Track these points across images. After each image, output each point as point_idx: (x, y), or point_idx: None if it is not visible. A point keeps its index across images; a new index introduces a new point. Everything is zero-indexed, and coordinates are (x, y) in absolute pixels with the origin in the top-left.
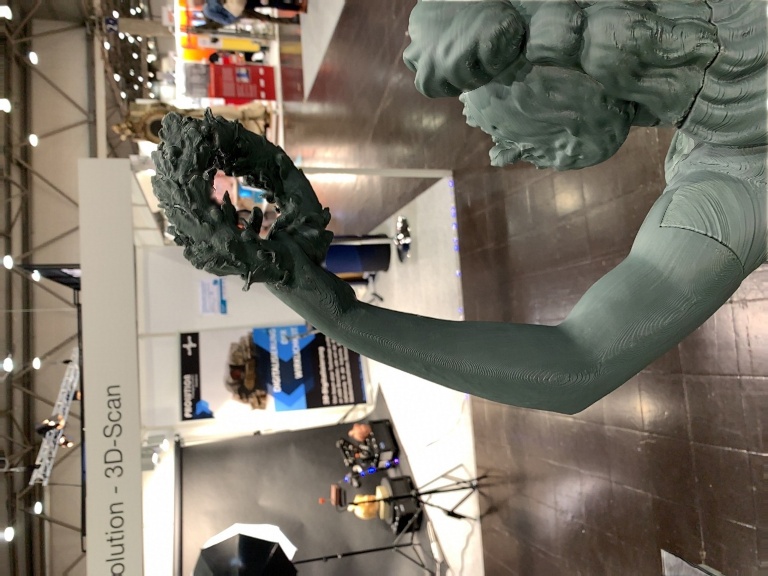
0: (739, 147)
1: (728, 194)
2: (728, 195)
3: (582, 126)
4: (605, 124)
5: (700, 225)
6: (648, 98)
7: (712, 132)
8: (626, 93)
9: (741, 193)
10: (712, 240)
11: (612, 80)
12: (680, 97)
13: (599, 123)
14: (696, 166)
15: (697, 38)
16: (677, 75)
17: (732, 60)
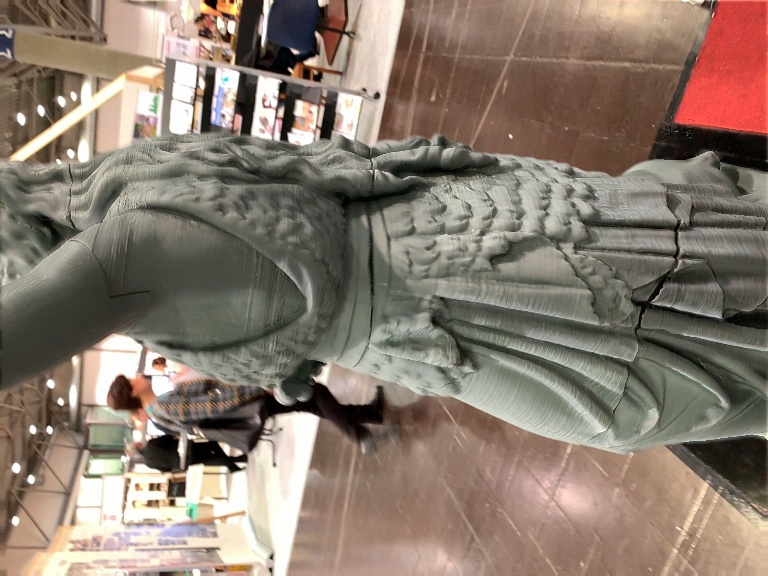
0: None
1: None
2: None
3: (2, 241)
4: (21, 237)
5: None
6: (38, 205)
7: (86, 211)
8: (23, 206)
9: None
10: None
11: (4, 194)
12: (59, 198)
13: (14, 236)
14: None
15: (58, 163)
16: (53, 187)
17: (79, 165)
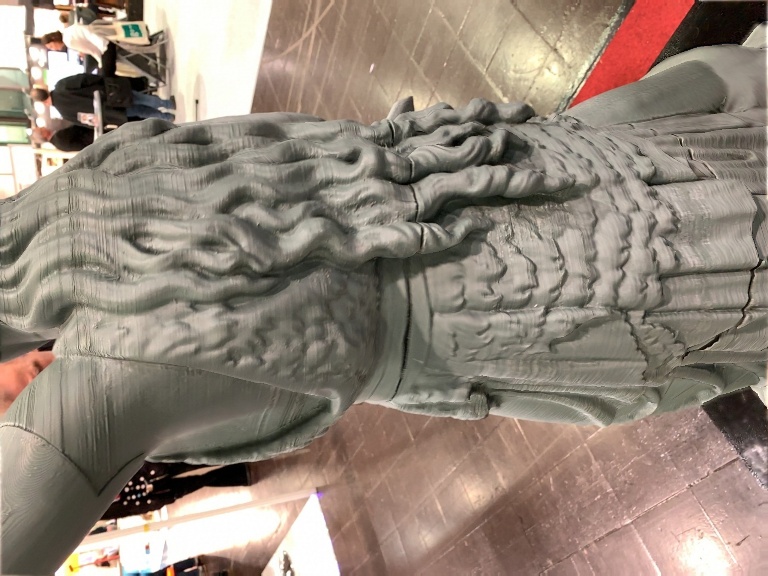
0: (59, 327)
1: (44, 376)
2: (44, 377)
3: None
4: None
5: (12, 417)
6: None
7: (22, 317)
8: None
9: (54, 371)
10: (18, 429)
11: None
12: None
13: None
14: None
15: None
16: None
17: None
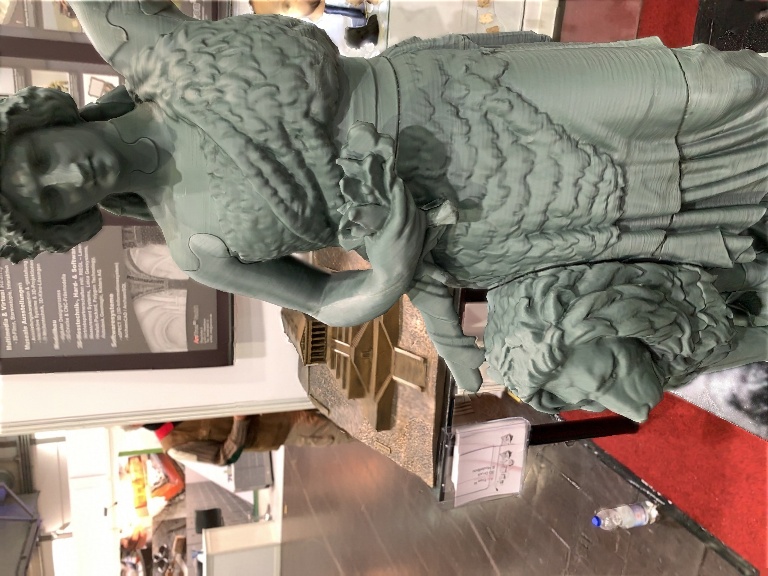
0: None
1: None
2: None
3: None
4: None
5: None
6: None
7: None
8: None
9: None
10: None
11: None
12: None
13: None
14: None
15: None
16: None
17: None
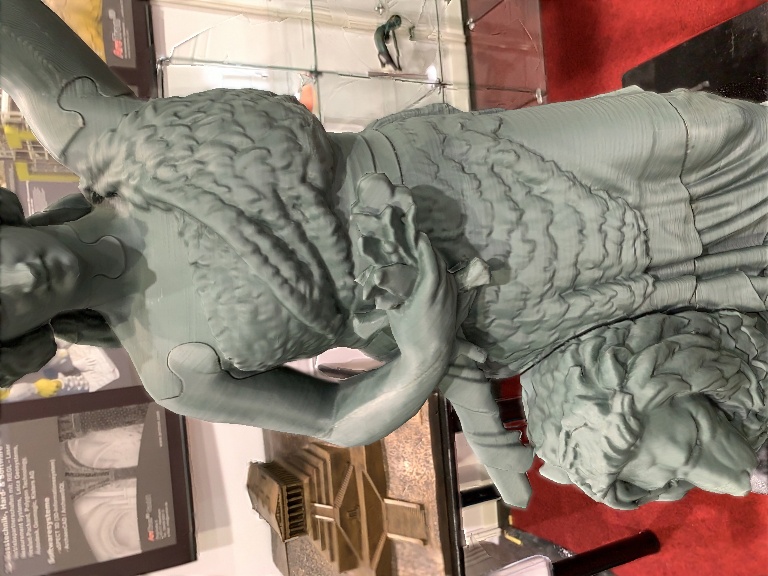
0: None
1: None
2: None
3: None
4: None
5: None
6: None
7: None
8: None
9: None
10: None
11: None
12: None
13: None
14: (80, 182)
15: None
16: None
17: None
